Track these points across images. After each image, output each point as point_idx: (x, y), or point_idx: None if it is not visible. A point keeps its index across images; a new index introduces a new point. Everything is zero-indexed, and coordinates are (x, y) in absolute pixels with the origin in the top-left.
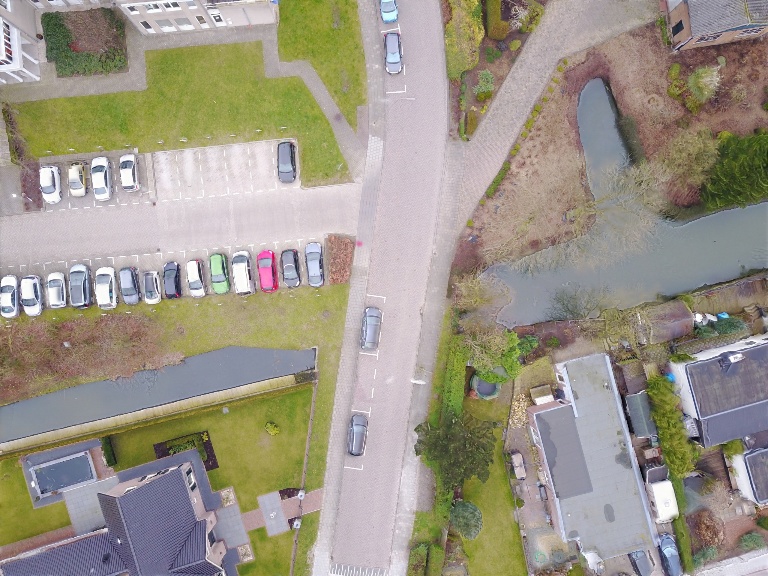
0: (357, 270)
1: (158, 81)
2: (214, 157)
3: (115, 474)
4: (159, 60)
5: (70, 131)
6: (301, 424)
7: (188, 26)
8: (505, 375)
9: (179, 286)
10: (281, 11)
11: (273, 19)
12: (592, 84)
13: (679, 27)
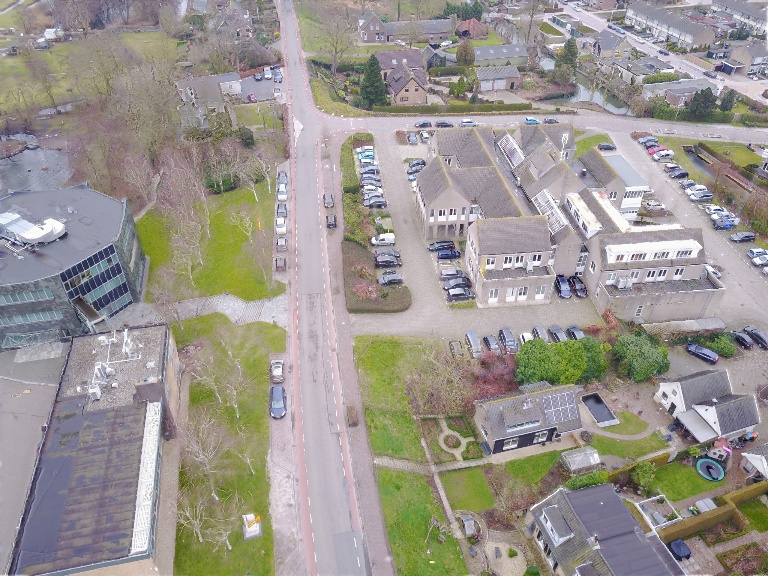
0: None
1: None
2: None
3: None
4: None
5: None
6: None
7: None
8: None
9: None
10: None
11: None
12: None
13: (512, 85)
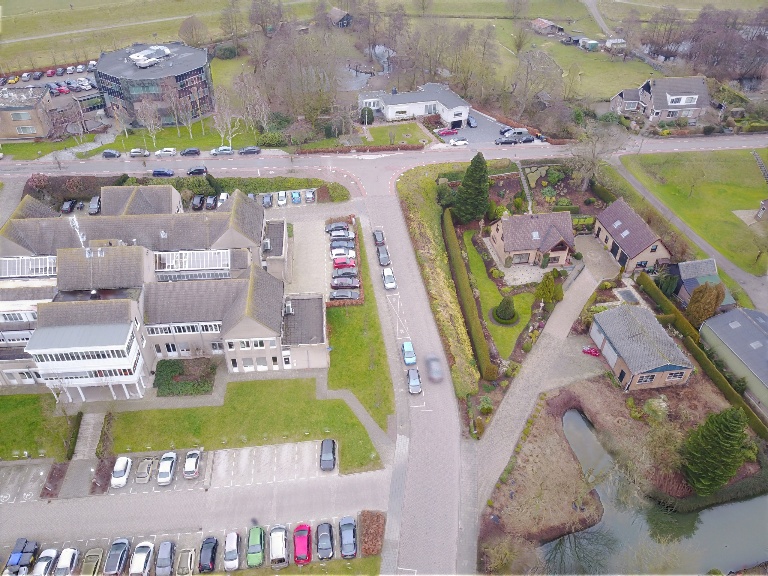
0: (388, 543)
1: (233, 400)
2: (267, 453)
3: None
4: (237, 388)
5: (152, 433)
6: None
7: (264, 367)
8: None
9: (214, 559)
10: (332, 362)
11: (326, 363)
12: (570, 413)
13: (622, 375)
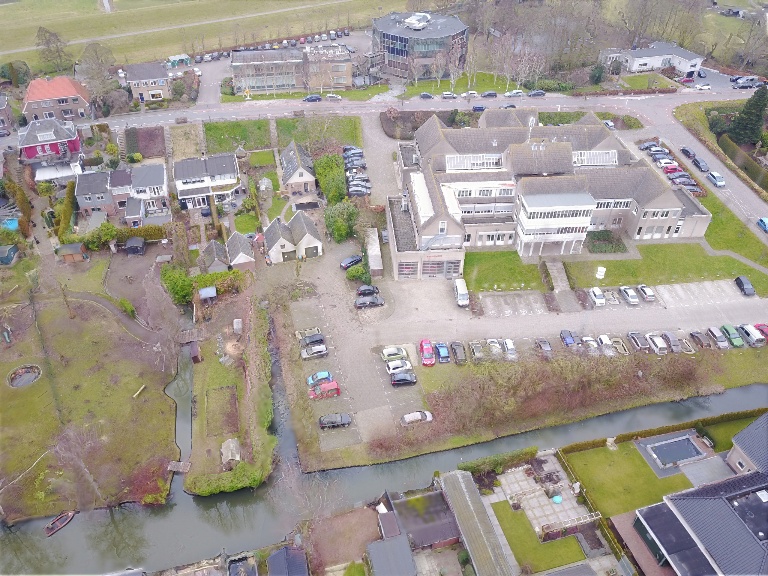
0: None
1: (648, 256)
2: (694, 287)
3: (717, 454)
4: (645, 248)
5: None
6: None
7: (658, 235)
8: None
9: None
10: None
11: None
12: None
13: None
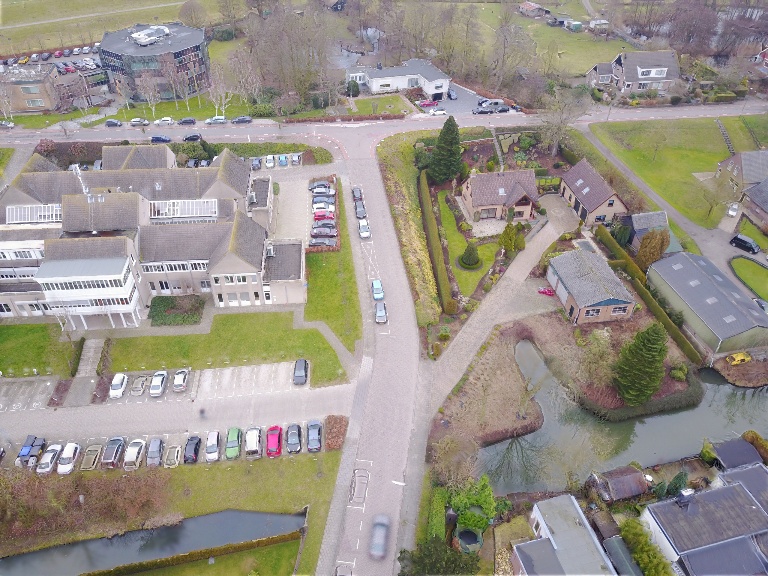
0: (349, 440)
1: (219, 329)
2: (247, 372)
3: None
4: (223, 319)
5: (146, 356)
6: (284, 575)
7: (247, 302)
8: (482, 514)
9: (197, 453)
10: (309, 298)
11: (303, 299)
12: (522, 343)
13: (572, 310)
